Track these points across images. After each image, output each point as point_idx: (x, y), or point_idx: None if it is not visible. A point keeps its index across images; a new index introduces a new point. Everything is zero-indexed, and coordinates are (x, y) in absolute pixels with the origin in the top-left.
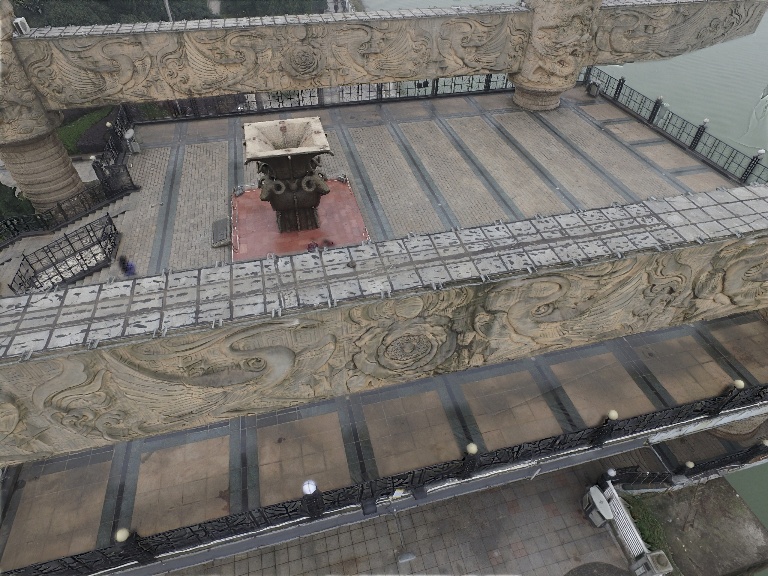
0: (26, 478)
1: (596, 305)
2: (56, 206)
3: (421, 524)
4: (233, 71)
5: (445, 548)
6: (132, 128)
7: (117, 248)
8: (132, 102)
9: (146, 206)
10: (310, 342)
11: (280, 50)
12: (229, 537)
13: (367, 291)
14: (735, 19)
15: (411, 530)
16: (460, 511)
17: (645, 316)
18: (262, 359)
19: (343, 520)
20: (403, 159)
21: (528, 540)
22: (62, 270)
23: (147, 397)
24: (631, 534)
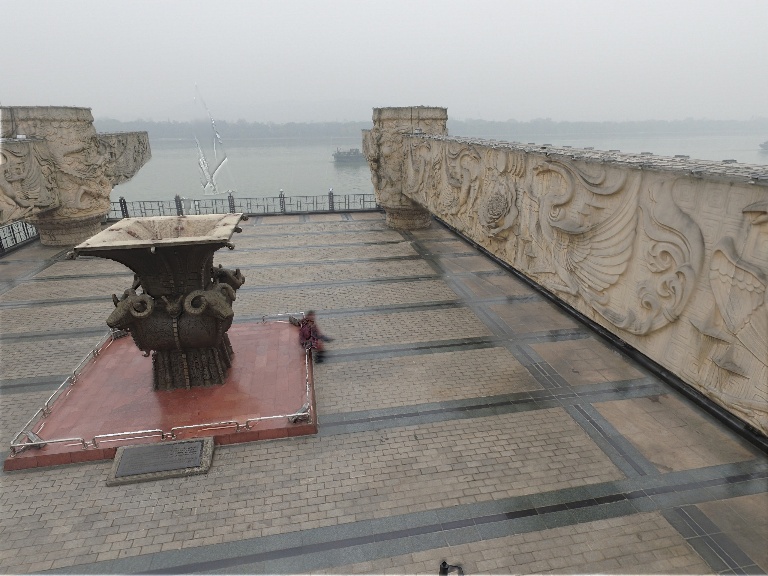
0: None
1: None
2: None
3: None
4: None
5: None
6: None
7: None
8: None
9: None
10: None
11: None
12: None
13: None
14: (142, 146)
15: None
16: None
17: None
18: None
19: None
20: (103, 303)
21: None
22: None
23: None
24: None
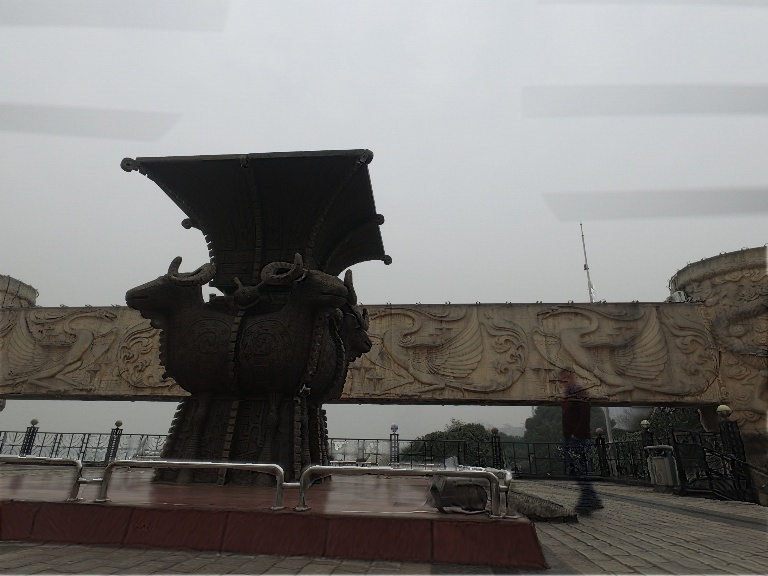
0: (625, 485)
1: None
2: None
3: None
4: None
5: None
6: None
7: None
8: None
9: None
10: None
11: None
12: None
13: None
14: None
15: None
16: None
17: None
18: None
19: None
20: None
21: None
22: None
23: None
24: None
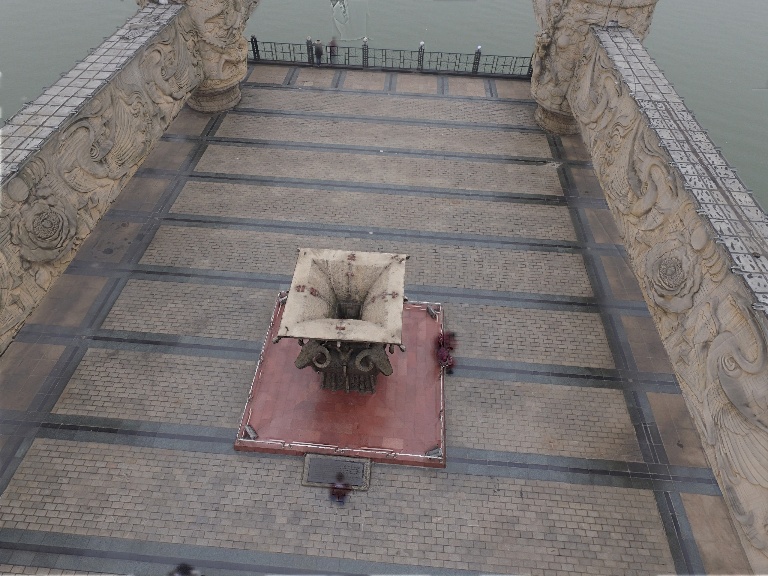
0: None
1: None
2: None
3: None
4: None
5: None
6: None
7: None
8: None
9: None
10: None
11: (7, 240)
12: None
13: None
14: None
15: None
16: None
17: None
18: None
19: None
20: (261, 233)
21: None
22: None
23: None
24: None
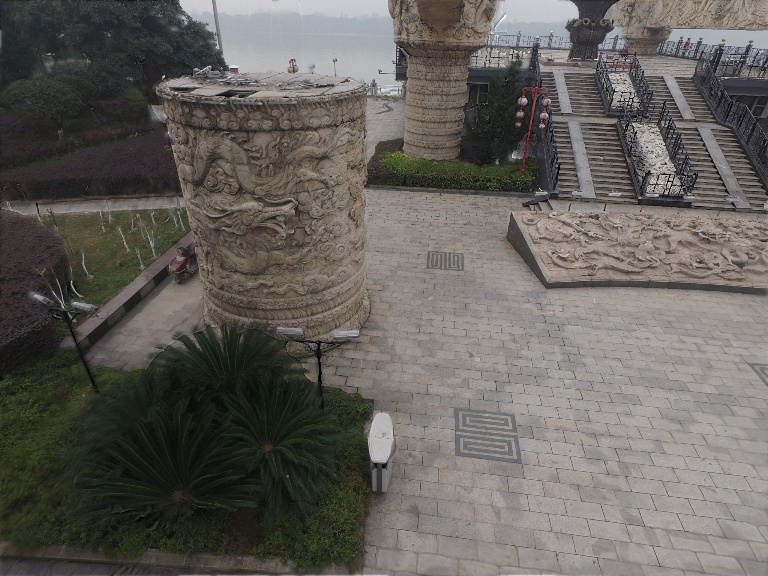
0: None
1: None
2: None
3: None
4: None
5: None
6: None
7: None
8: None
9: None
10: None
11: None
12: None
13: None
14: None
15: None
16: None
17: None
18: None
19: None
20: None
21: None
22: (640, 79)
23: None
24: None
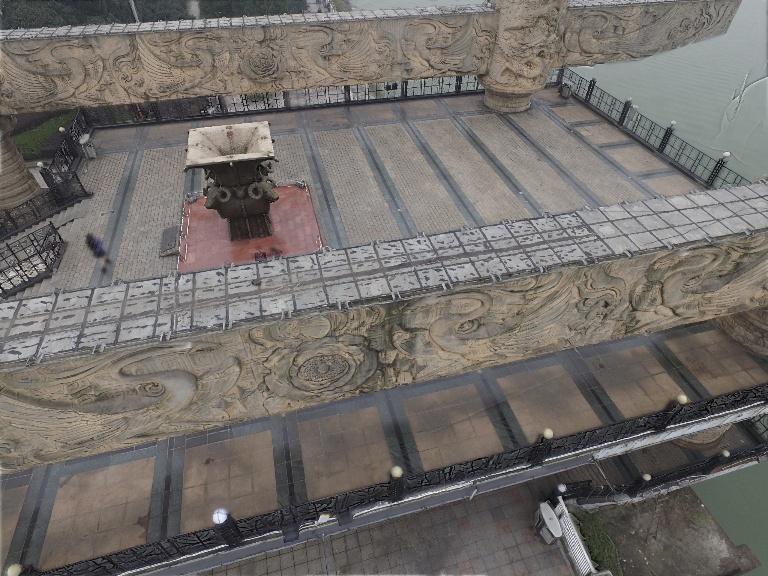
0: None
1: (526, 320)
2: (4, 214)
3: (367, 543)
4: (190, 74)
5: (390, 568)
6: (91, 132)
7: (61, 258)
8: (86, 106)
9: (96, 214)
10: (211, 365)
11: (238, 52)
12: (141, 568)
13: (267, 311)
14: (706, 19)
15: (356, 550)
16: (408, 529)
17: (582, 330)
18: (159, 384)
19: (268, 546)
20: (366, 163)
21: (476, 559)
22: (1, 281)
23: (36, 425)
24: (580, 552)
